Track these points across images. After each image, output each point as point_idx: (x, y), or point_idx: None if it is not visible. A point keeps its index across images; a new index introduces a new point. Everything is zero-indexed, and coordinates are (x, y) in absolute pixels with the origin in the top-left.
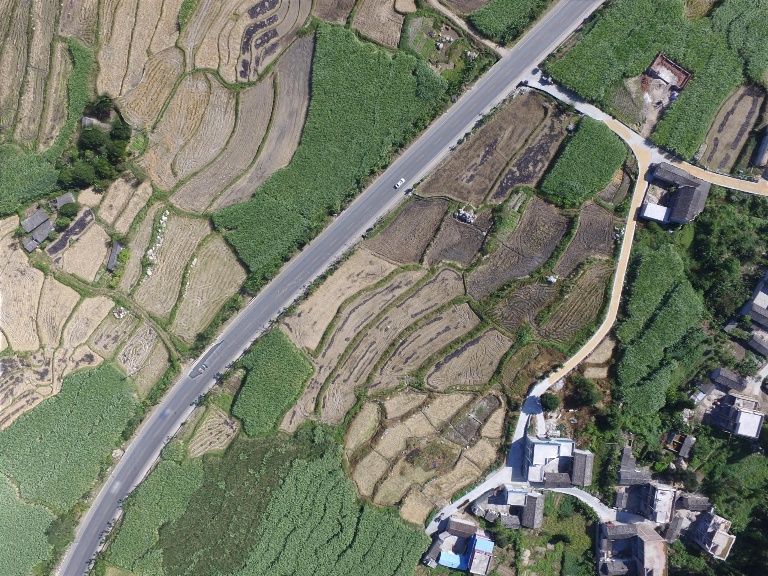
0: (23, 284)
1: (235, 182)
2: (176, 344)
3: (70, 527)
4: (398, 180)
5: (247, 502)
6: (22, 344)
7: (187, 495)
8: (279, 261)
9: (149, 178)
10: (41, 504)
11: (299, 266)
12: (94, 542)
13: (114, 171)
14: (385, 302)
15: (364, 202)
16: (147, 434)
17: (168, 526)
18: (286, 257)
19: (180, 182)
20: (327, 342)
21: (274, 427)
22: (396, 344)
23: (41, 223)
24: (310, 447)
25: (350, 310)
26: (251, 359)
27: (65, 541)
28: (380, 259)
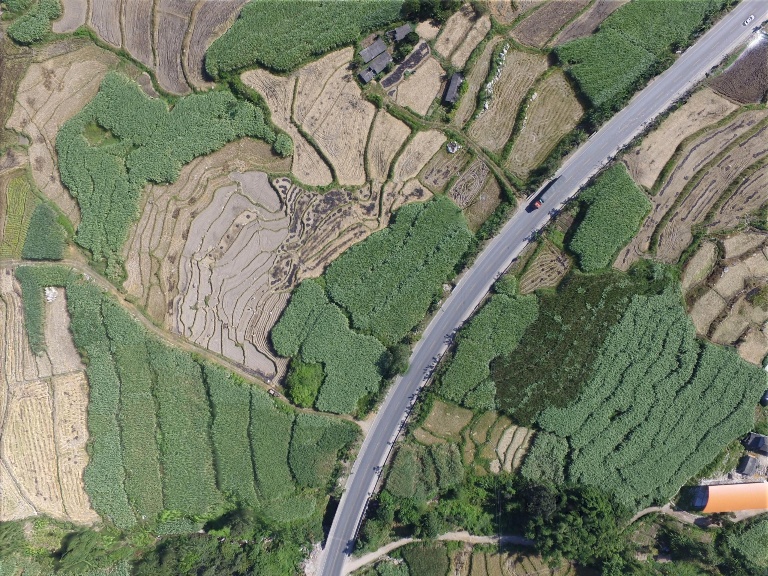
0: (354, 117)
1: (577, 17)
2: (512, 178)
3: (408, 355)
4: (748, 17)
5: (582, 337)
6: (348, 178)
7: (521, 329)
8: (625, 95)
9: (489, 12)
10: (371, 335)
11: (642, 102)
12: (418, 377)
13: (459, 1)
14: (726, 141)
15: (712, 38)
16: (479, 268)
17: (501, 359)
18: (631, 91)
19: (521, 16)
20: (666, 180)
21: (607, 265)
22: (740, 182)
23: (378, 54)
24: (648, 283)
25: (691, 148)
26: (592, 193)
27: (393, 373)
28: (722, 98)
